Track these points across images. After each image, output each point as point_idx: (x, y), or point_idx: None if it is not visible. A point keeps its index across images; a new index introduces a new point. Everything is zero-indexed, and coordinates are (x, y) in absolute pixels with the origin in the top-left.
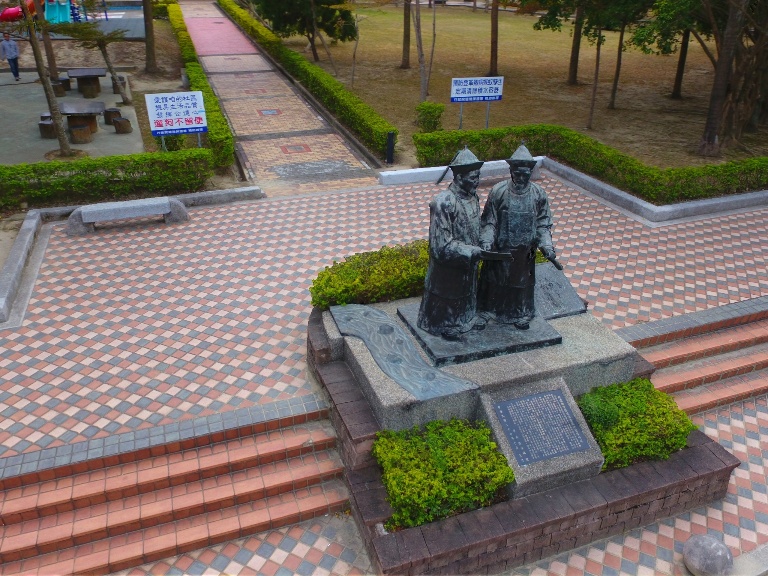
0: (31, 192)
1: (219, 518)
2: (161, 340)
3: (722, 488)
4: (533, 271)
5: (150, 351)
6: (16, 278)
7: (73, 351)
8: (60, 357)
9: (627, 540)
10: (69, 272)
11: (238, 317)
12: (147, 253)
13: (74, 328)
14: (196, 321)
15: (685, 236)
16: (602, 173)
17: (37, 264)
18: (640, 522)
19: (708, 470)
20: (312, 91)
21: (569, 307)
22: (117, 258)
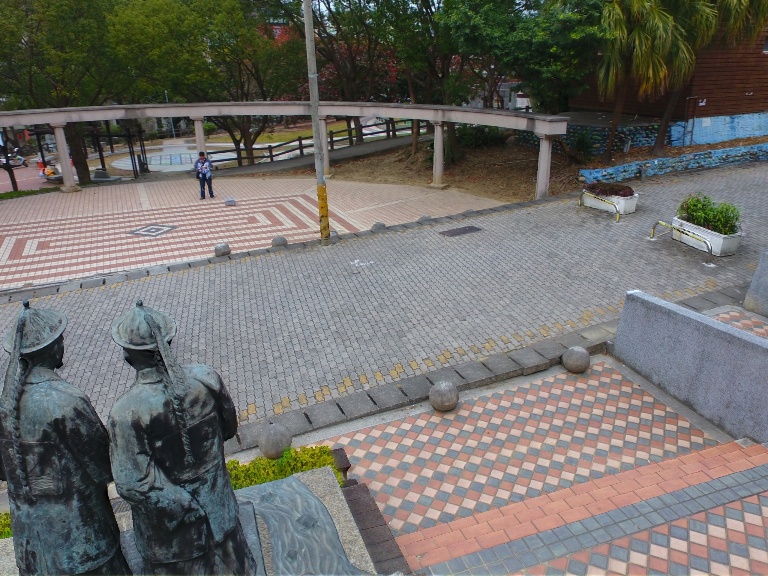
0: None
1: None
2: None
3: None
4: None
5: None
6: None
7: None
8: None
9: None
10: None
11: None
12: None
13: None
14: None
15: None
16: None
17: None
18: None
19: None
20: None
21: None
22: None
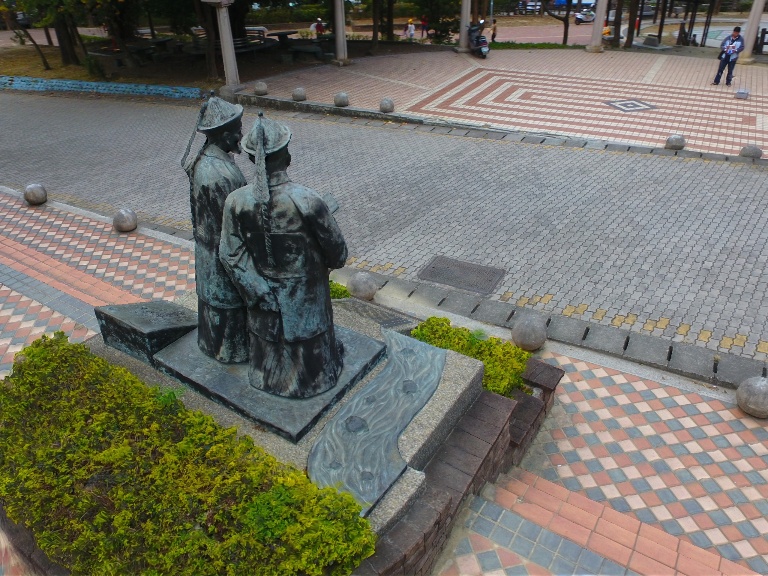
0: None
1: None
2: None
3: None
4: None
5: None
6: None
7: None
8: None
9: None
10: None
11: None
12: None
13: None
14: None
15: None
16: None
17: None
18: None
19: None
20: None
21: (177, 307)
22: None
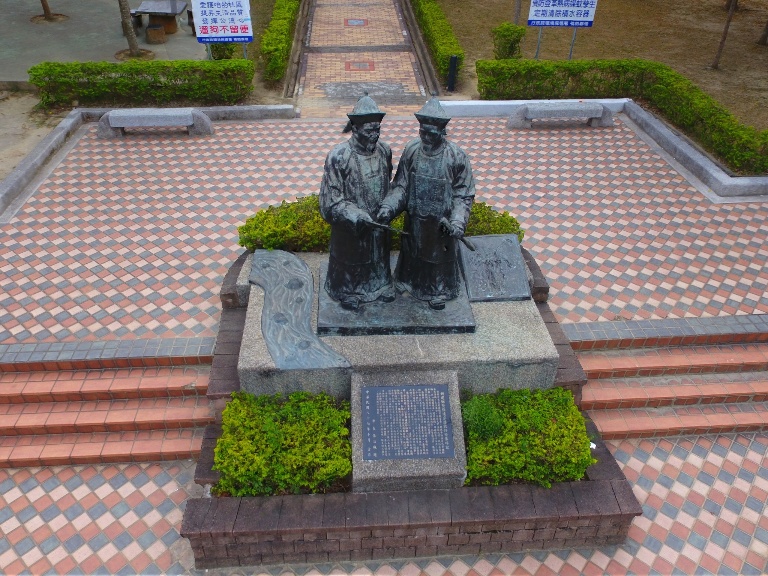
0: (80, 91)
1: (87, 441)
2: (113, 256)
3: (619, 534)
4: (451, 246)
5: (98, 266)
6: (26, 176)
7: (35, 254)
8: (21, 259)
9: (479, 563)
10: (77, 175)
11: (196, 243)
12: (154, 164)
13: (49, 232)
14: (155, 242)
15: (750, 219)
16: (689, 127)
17: (56, 163)
18: (501, 548)
19: (594, 512)
20: (411, 1)
21: (510, 291)
22: (126, 166)
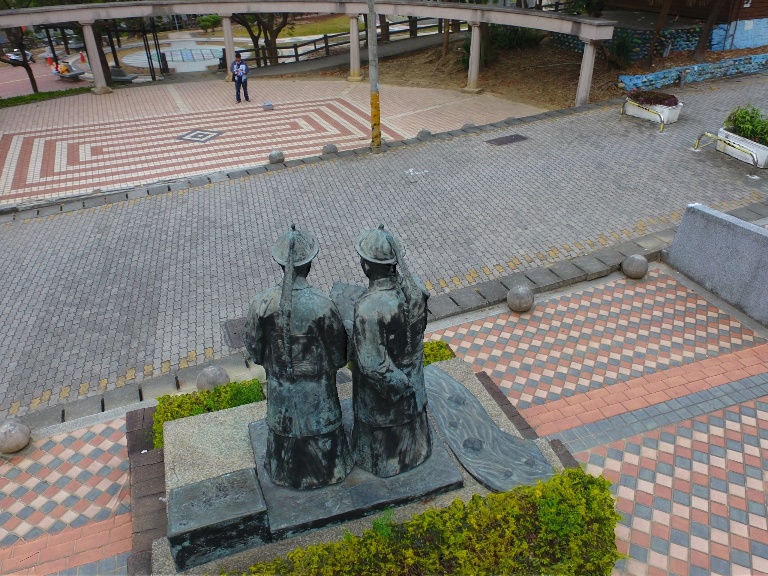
0: None
1: None
2: None
3: None
4: None
5: None
6: None
7: None
8: None
9: None
10: None
11: None
12: None
13: None
14: None
15: None
16: None
17: None
18: None
19: None
20: None
21: (199, 485)
22: None
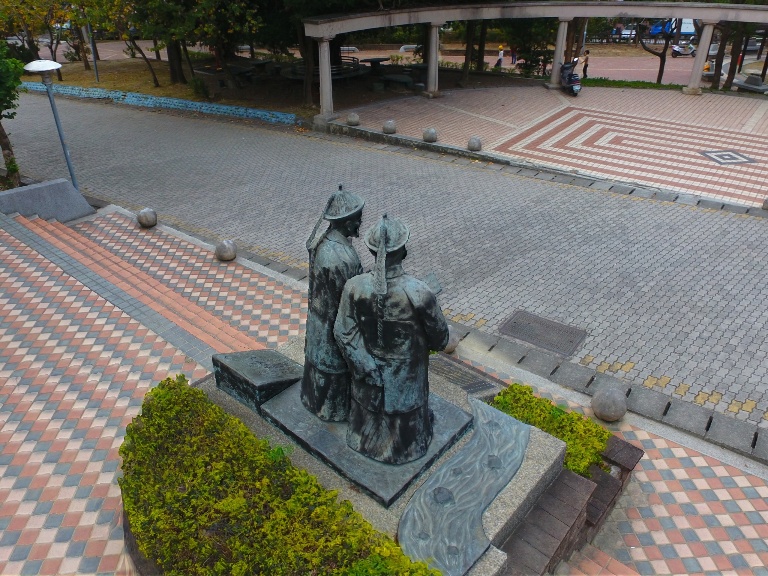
0: None
1: None
2: None
3: None
4: None
5: None
6: None
7: None
8: None
9: None
10: None
11: None
12: None
13: None
14: None
15: None
16: None
17: None
18: None
19: None
20: None
21: (281, 357)
22: None
